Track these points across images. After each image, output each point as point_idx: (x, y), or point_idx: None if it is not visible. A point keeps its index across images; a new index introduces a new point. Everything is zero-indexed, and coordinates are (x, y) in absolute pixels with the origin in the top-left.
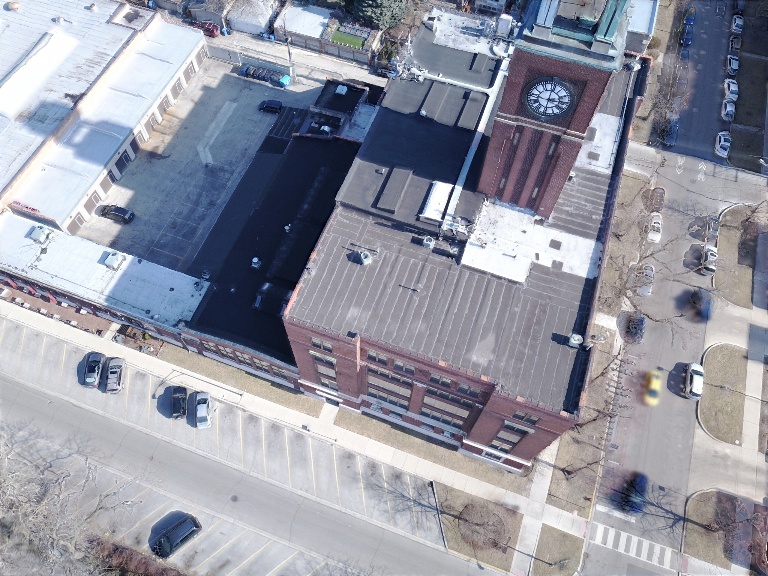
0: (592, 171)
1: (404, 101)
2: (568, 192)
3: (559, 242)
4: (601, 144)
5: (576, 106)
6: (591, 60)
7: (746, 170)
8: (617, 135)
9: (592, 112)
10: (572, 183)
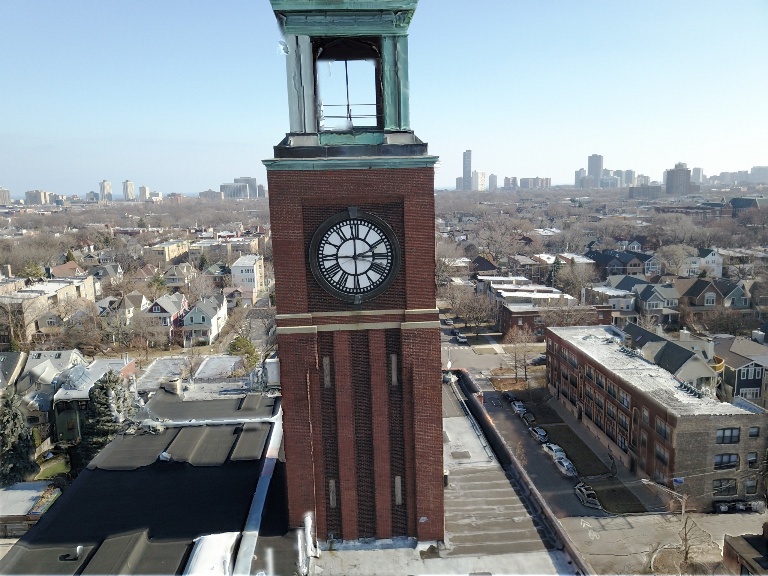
0: (470, 469)
1: (131, 456)
2: (452, 500)
3: (485, 573)
4: (462, 442)
5: (403, 254)
6: (395, 157)
7: (632, 513)
8: (476, 430)
9: (432, 257)
10: (451, 489)
